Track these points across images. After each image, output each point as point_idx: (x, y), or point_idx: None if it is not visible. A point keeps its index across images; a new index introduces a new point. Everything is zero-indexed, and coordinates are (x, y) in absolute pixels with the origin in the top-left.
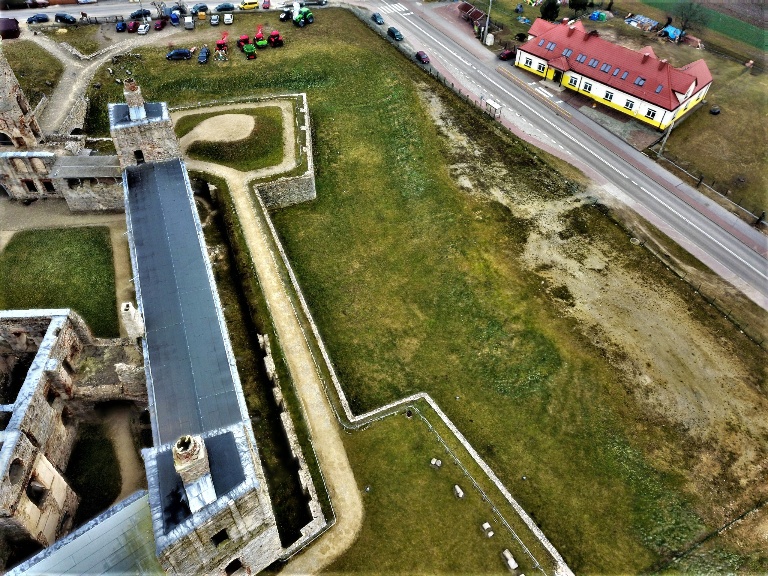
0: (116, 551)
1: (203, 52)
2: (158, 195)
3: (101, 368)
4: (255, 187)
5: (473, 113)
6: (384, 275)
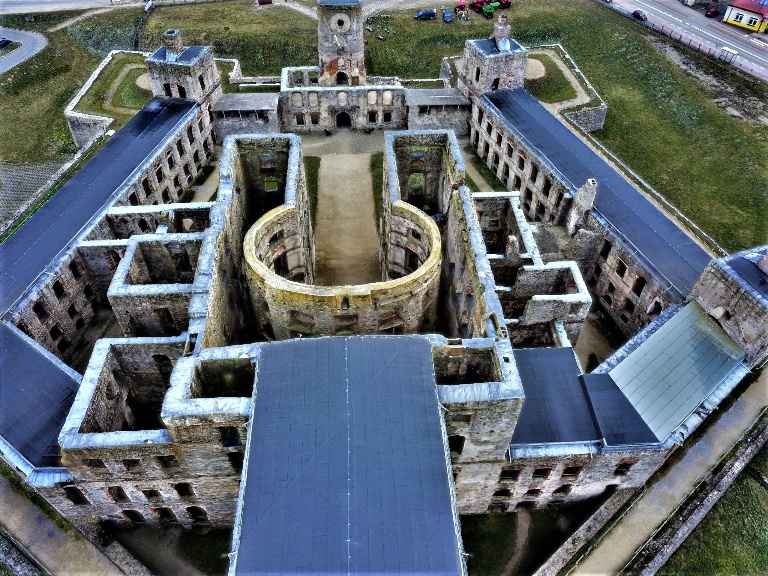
0: (693, 337)
1: (448, 12)
2: (528, 113)
3: (536, 242)
4: (566, 115)
5: (709, 59)
6: (694, 185)
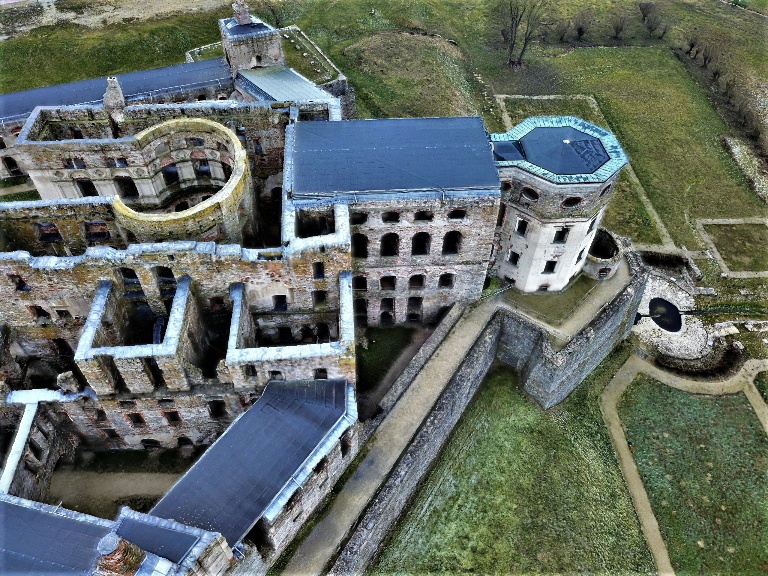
0: None
1: None
2: None
3: None
4: None
5: None
6: None
